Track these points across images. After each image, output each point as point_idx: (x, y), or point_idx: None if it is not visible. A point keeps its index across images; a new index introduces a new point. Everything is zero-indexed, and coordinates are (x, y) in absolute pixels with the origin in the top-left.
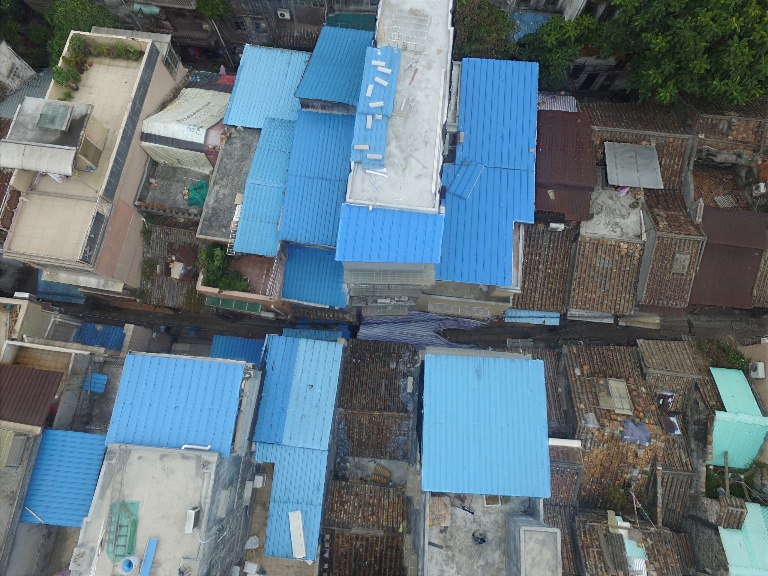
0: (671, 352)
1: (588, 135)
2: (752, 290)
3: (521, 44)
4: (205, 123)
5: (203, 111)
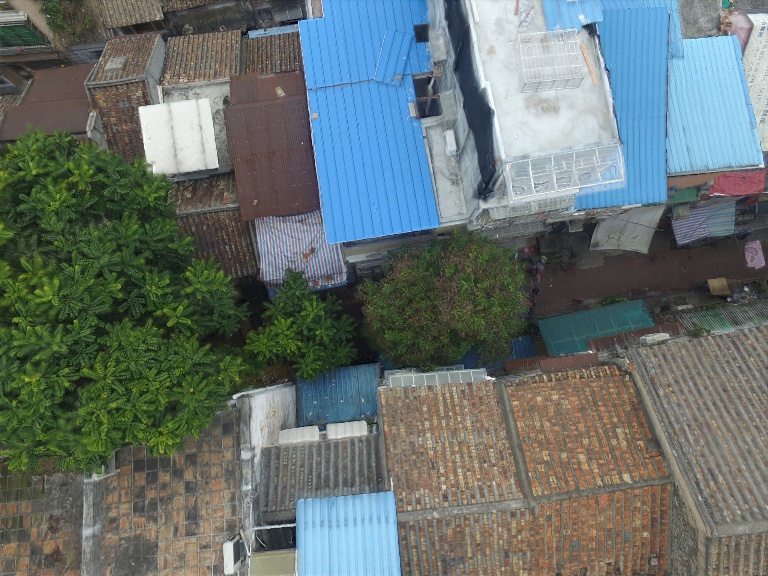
0: (126, 6)
1: (241, 184)
2: (33, 83)
3: (353, 341)
4: (759, 48)
5: (767, 91)
